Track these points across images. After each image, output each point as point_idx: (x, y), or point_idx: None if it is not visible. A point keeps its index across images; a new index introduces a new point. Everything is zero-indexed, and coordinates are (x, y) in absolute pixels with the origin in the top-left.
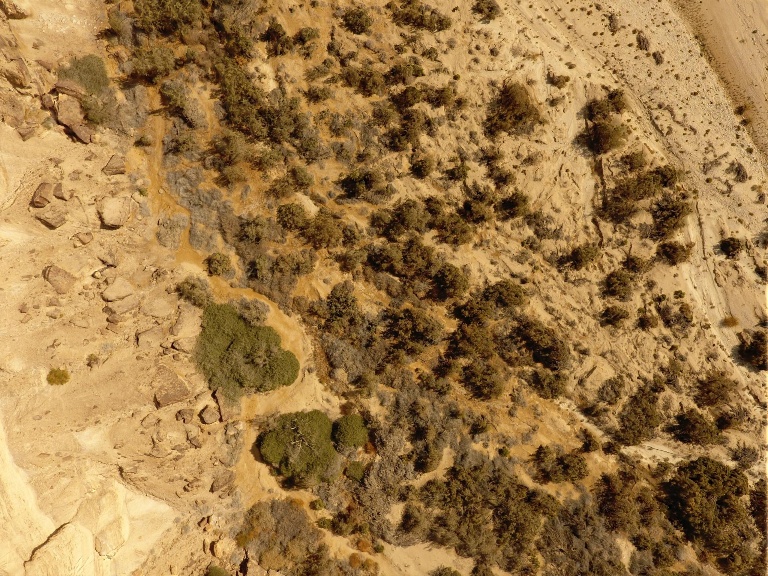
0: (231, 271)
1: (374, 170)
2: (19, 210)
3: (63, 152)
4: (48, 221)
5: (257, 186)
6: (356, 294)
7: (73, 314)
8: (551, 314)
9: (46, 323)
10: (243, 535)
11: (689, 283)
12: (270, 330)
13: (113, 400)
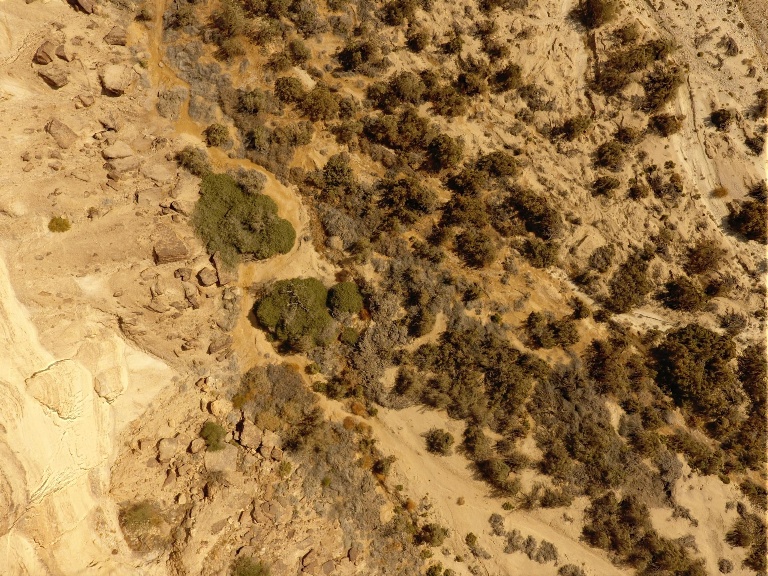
0: (229, 141)
1: (370, 43)
2: (22, 65)
3: (65, 19)
4: (50, 78)
5: (255, 60)
6: (352, 165)
7: (74, 168)
8: (543, 185)
9: (48, 174)
10: (239, 397)
11: (680, 155)
12: (267, 198)
13: (113, 250)
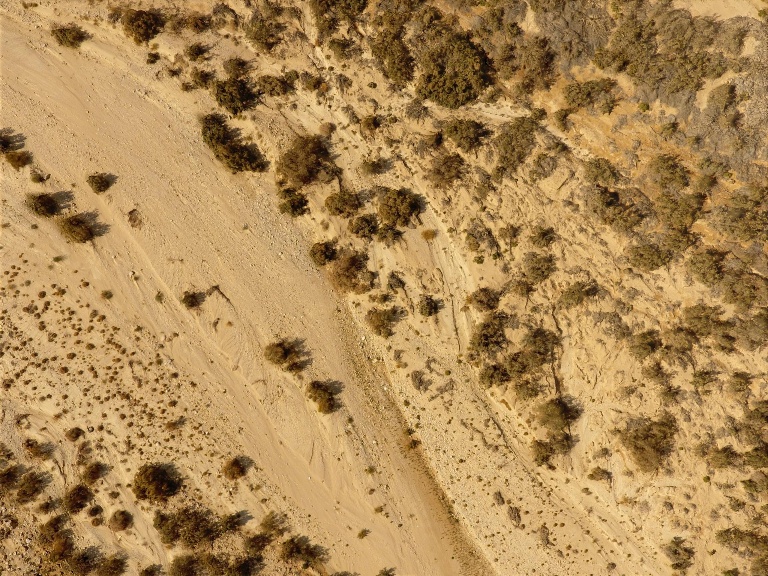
0: None
1: None
2: None
3: None
4: None
5: None
6: None
7: None
8: (601, 239)
9: None
10: None
11: (467, 272)
12: None
13: None
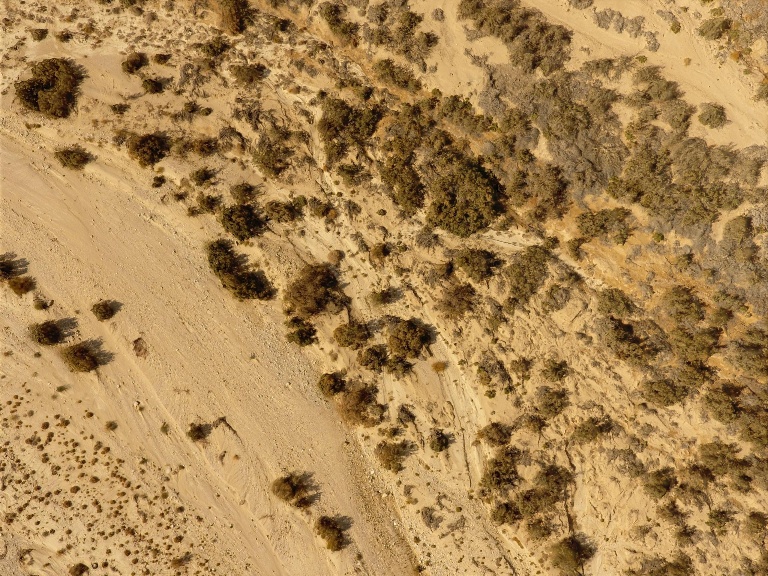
0: None
1: None
2: None
3: None
4: None
5: None
6: None
7: None
8: (615, 373)
9: None
10: None
11: (478, 405)
12: None
13: None
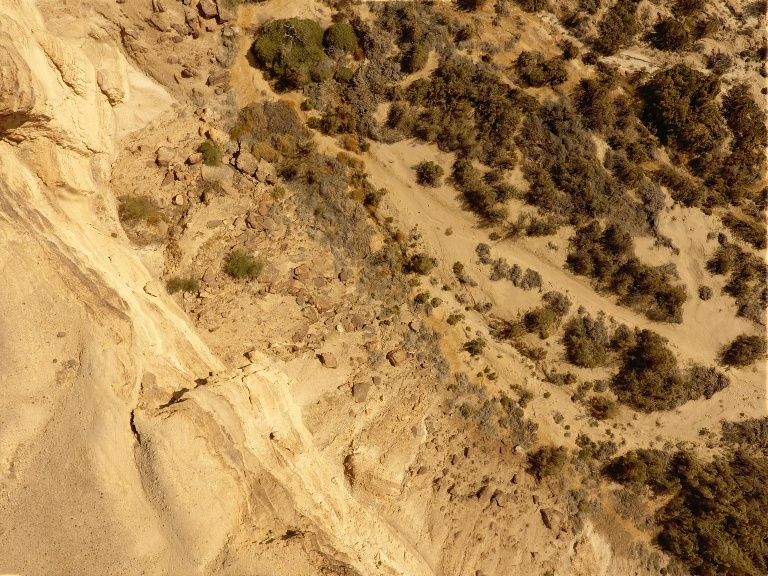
0: None
1: None
2: None
3: None
4: None
5: None
6: None
7: None
8: None
9: None
10: (237, 129)
11: None
12: None
13: None
